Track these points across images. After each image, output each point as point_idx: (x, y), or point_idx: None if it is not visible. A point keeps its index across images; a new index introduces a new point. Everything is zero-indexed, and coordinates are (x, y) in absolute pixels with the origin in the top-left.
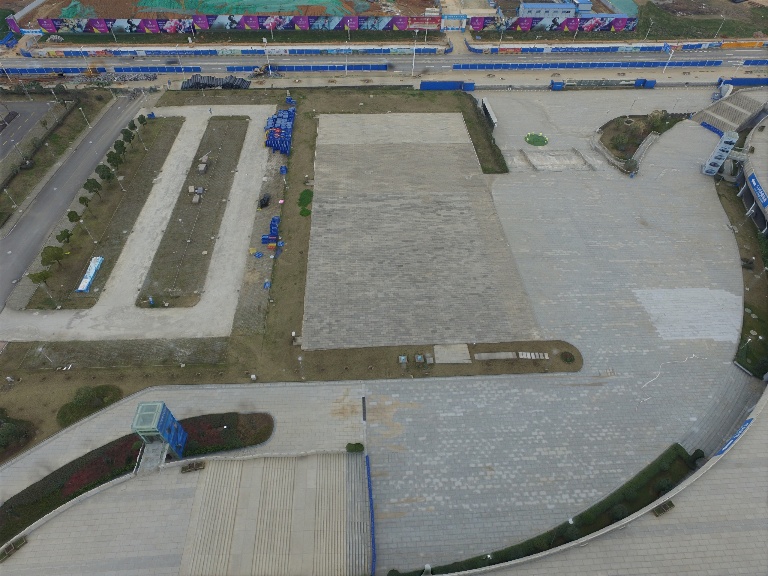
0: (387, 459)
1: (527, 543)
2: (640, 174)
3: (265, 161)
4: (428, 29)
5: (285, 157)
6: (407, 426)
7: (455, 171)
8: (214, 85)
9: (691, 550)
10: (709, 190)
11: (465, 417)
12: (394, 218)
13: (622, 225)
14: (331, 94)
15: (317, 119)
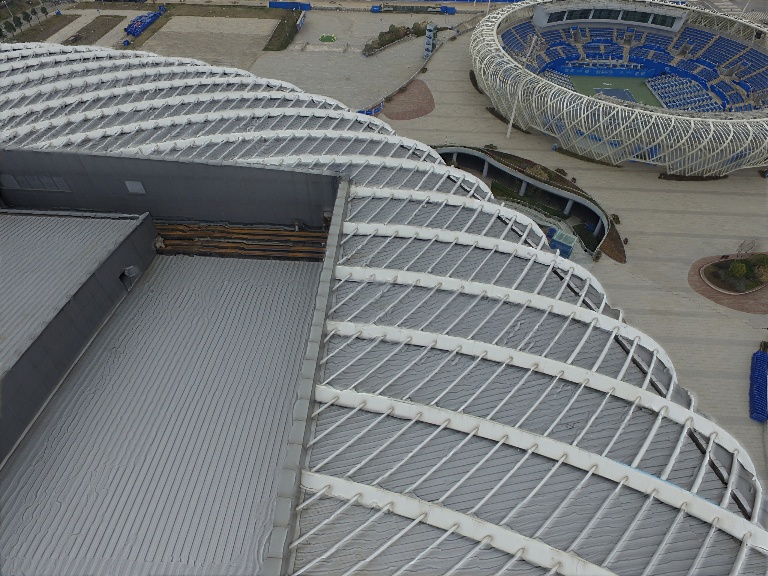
0: None
1: None
2: (375, 56)
3: (118, 39)
4: None
5: (134, 38)
6: None
7: (242, 48)
8: (119, 0)
9: None
10: (416, 66)
11: None
12: None
13: (330, 79)
14: (195, 6)
15: (171, 18)
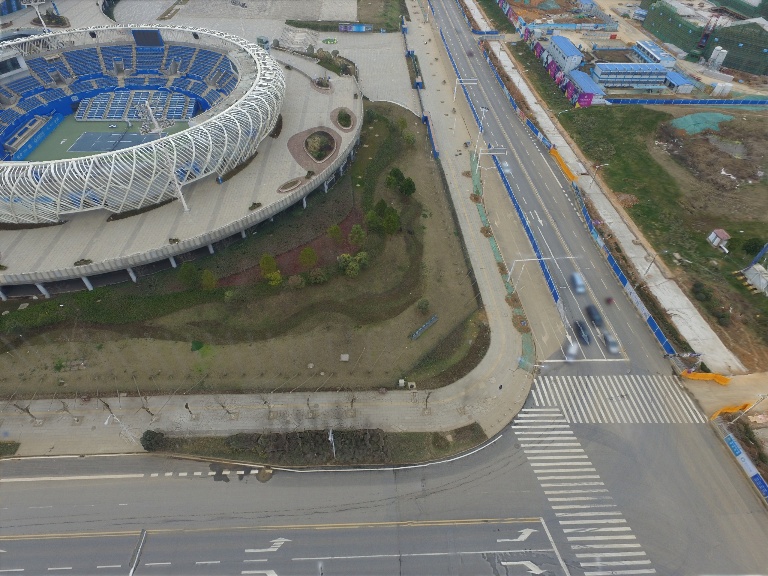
0: (151, 0)
1: (113, 8)
2: (271, 49)
3: None
4: None
5: None
6: (158, 2)
7: None
8: None
9: (86, 5)
10: None
11: (155, 7)
12: None
13: None
14: (385, 0)
15: None
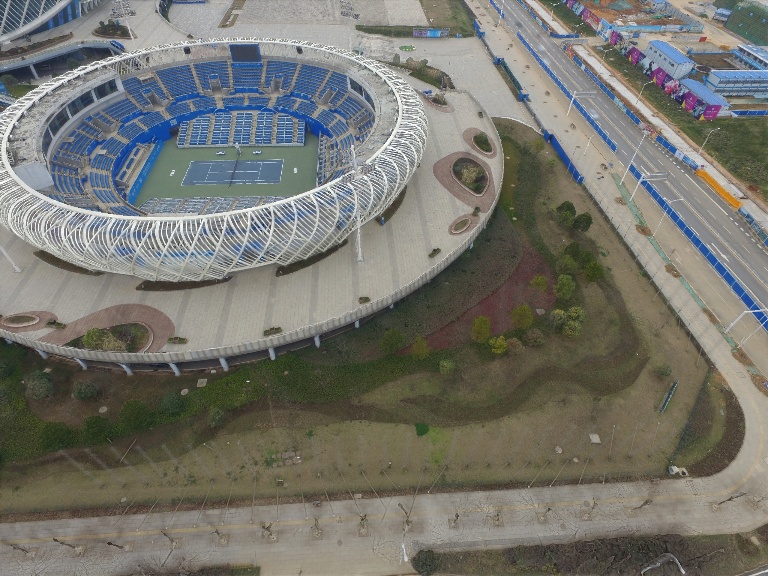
0: None
1: None
2: None
3: None
4: (593, 28)
5: None
6: None
7: None
8: None
9: None
10: None
11: None
12: (317, 7)
13: None
14: (447, 1)
15: None
